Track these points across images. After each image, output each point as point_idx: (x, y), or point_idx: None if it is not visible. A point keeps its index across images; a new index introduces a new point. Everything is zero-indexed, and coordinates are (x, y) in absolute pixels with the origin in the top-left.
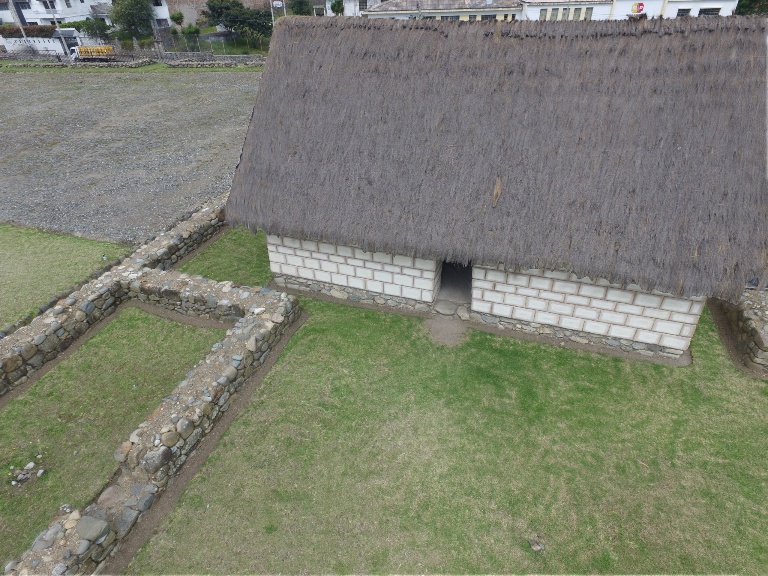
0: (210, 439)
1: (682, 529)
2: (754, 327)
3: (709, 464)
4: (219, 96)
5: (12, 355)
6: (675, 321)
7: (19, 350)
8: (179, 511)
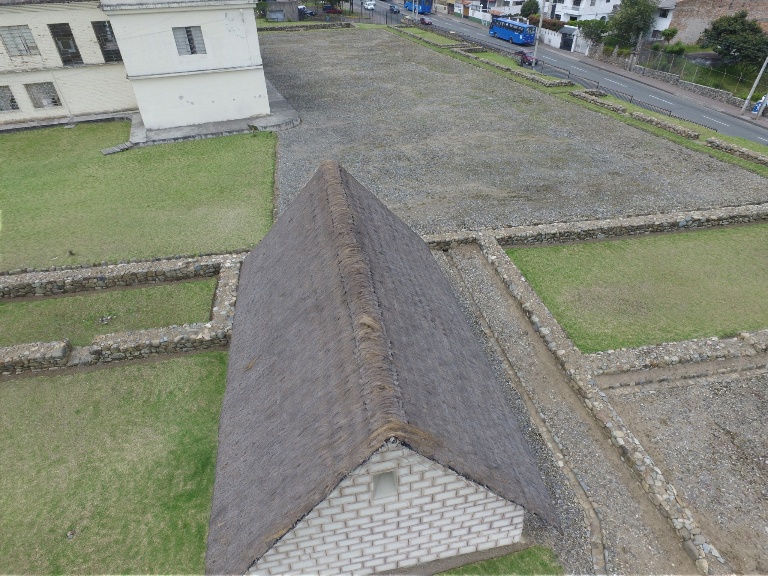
0: (127, 362)
1: None
2: None
3: None
4: None
5: (152, 270)
6: None
7: (157, 270)
8: (83, 375)
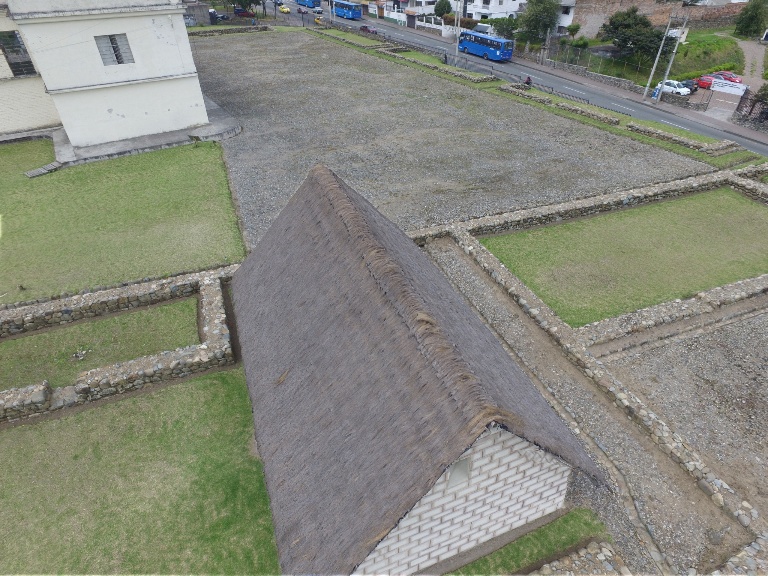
0: (119, 397)
1: None
2: None
3: None
4: None
5: (124, 296)
6: None
7: (129, 295)
8: (72, 418)
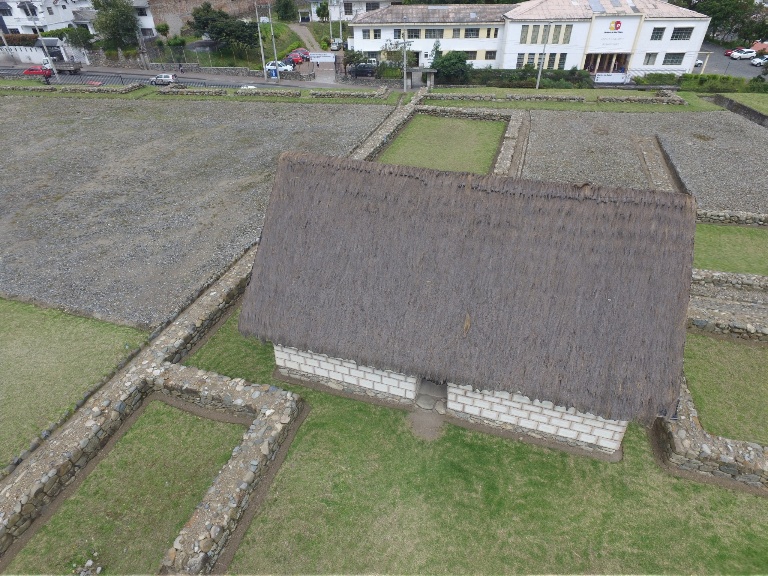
0: (235, 537)
1: None
2: (671, 431)
3: (626, 555)
4: (212, 137)
5: (64, 461)
6: (608, 429)
7: (69, 456)
8: None
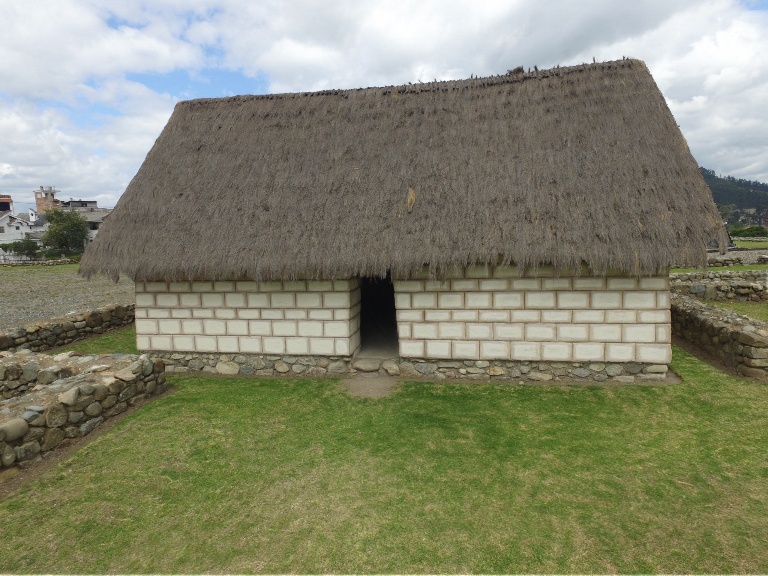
0: None
1: None
2: (732, 331)
3: None
4: None
5: None
6: (645, 323)
7: None
8: None
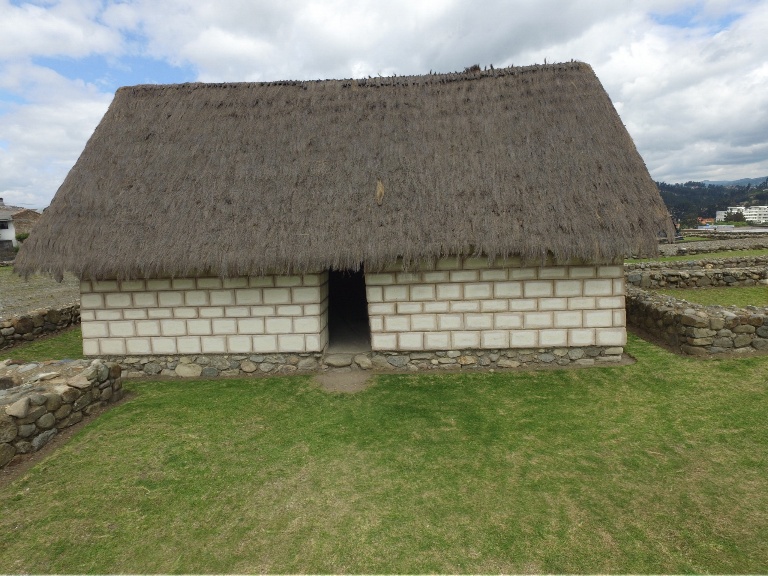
0: None
1: (759, 508)
2: (675, 314)
3: (726, 436)
4: None
5: None
6: (603, 309)
7: None
8: None
